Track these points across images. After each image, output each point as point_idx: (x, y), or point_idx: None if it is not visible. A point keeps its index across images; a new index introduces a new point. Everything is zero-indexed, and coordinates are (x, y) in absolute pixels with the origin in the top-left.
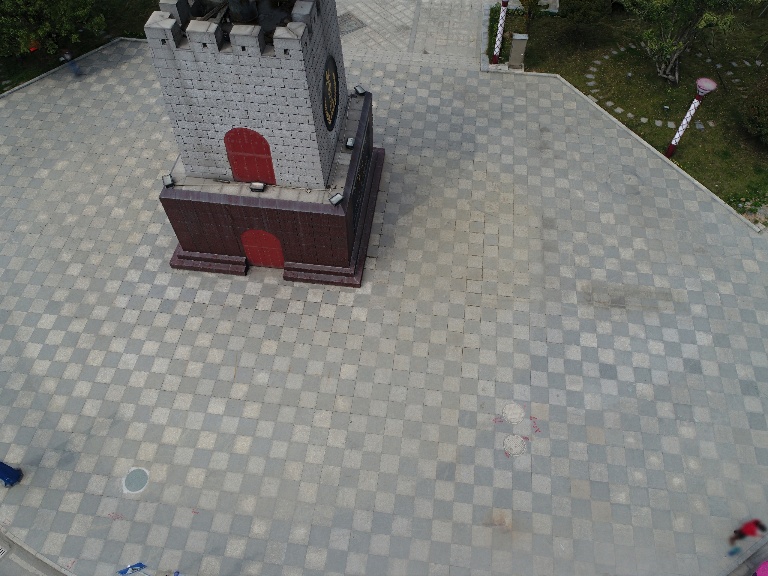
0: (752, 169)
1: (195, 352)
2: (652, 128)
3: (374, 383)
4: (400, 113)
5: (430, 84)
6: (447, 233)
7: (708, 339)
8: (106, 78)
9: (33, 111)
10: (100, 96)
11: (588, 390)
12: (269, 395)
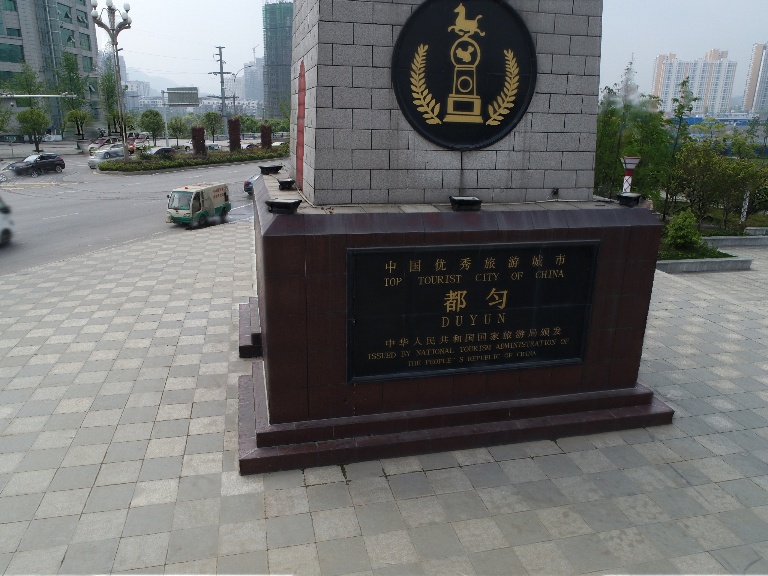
0: None
1: (80, 353)
2: None
3: None
4: None
5: None
6: None
7: None
8: None
9: None
10: None
11: None
12: None
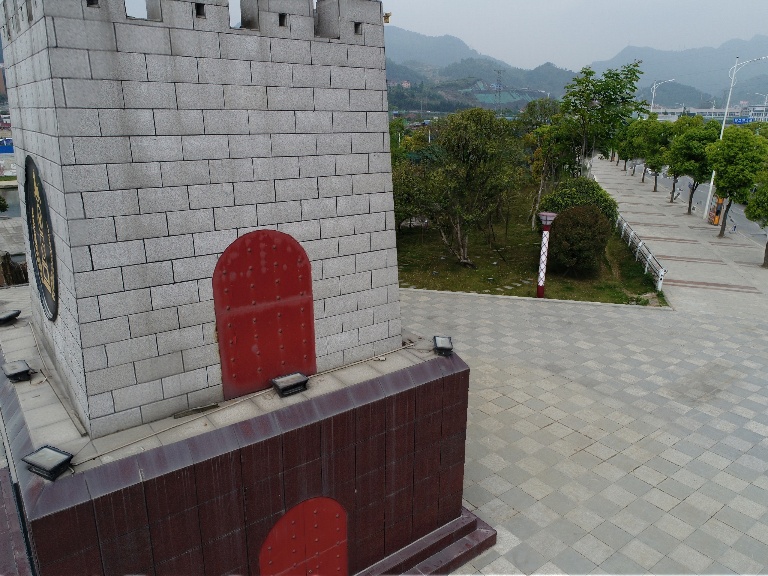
0: (596, 289)
1: None
2: None
3: None
4: None
5: None
6: (488, 422)
7: None
8: None
9: None
10: None
11: None
12: None
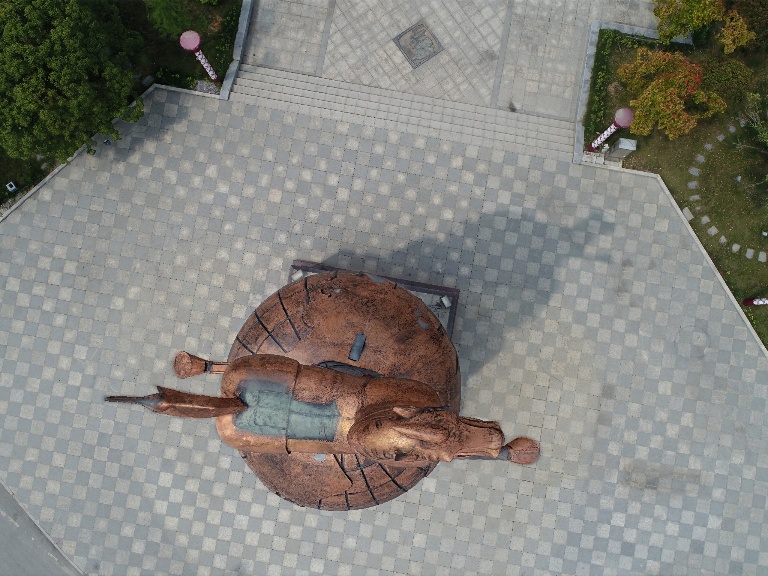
0: None
1: (294, 516)
2: (741, 263)
3: (440, 552)
4: (477, 230)
5: (513, 183)
6: (512, 399)
7: (718, 523)
8: (151, 157)
9: (84, 209)
10: (151, 187)
11: (608, 565)
12: (357, 558)
